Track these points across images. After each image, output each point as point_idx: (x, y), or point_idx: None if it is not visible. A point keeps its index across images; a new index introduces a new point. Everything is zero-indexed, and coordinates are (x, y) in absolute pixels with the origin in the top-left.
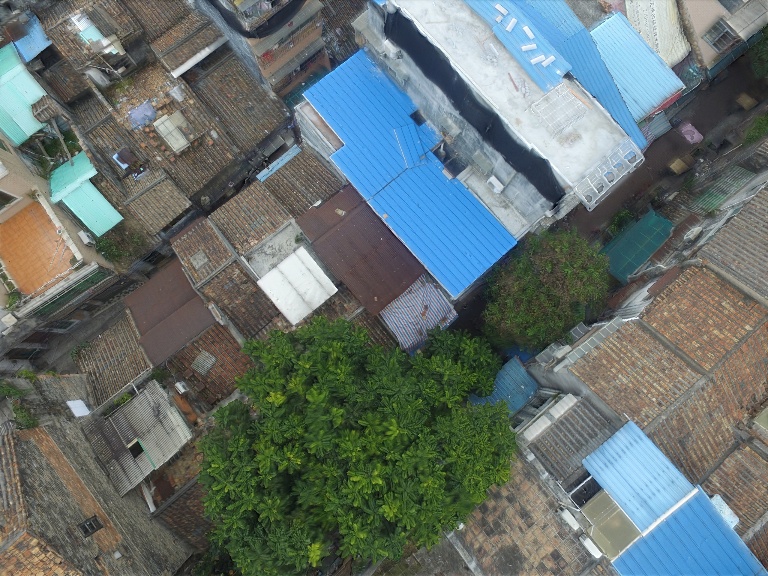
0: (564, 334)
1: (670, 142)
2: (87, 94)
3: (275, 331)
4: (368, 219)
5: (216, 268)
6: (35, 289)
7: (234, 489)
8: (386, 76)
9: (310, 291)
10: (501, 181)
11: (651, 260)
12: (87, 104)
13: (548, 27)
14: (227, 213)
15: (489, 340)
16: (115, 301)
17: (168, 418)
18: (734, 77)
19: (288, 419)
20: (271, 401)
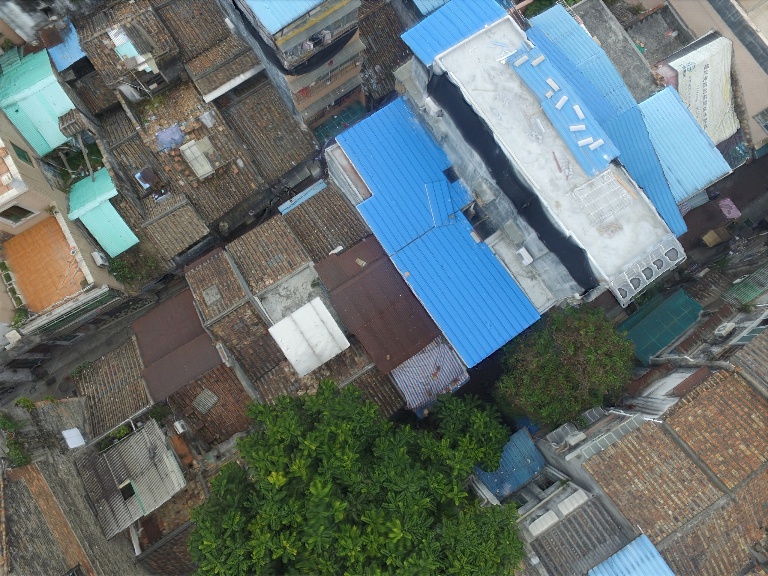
0: (579, 417)
1: (704, 211)
2: (116, 107)
3: (283, 397)
4: (389, 273)
5: (228, 307)
6: (42, 307)
7: (224, 571)
8: (423, 128)
9: (322, 344)
10: (531, 254)
11: (677, 349)
12: (114, 118)
13: (596, 97)
14: (245, 246)
15: (499, 407)
16: (122, 316)
17: (163, 462)
18: None
19: (288, 504)
20: (272, 482)
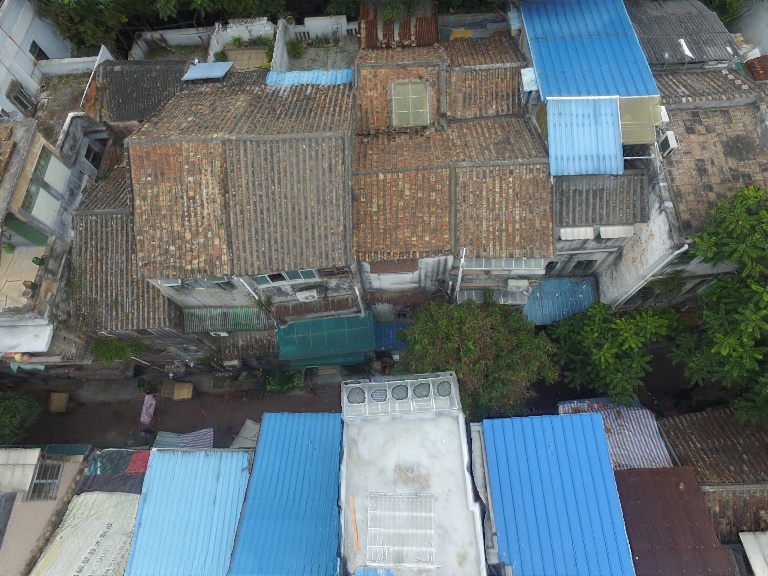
0: (491, 302)
1: None
2: None
3: None
4: None
5: None
6: None
7: None
8: None
9: None
10: None
11: None
12: None
13: None
14: None
15: None
16: None
17: None
18: (40, 437)
19: None
20: None
